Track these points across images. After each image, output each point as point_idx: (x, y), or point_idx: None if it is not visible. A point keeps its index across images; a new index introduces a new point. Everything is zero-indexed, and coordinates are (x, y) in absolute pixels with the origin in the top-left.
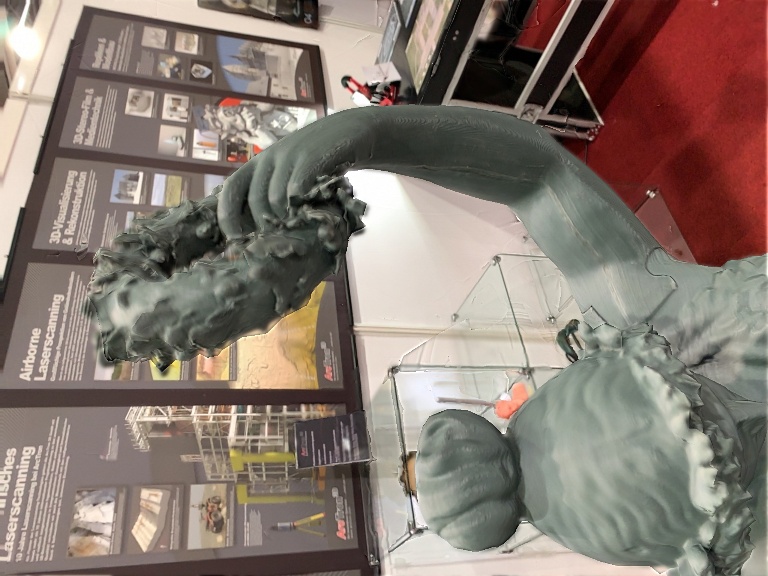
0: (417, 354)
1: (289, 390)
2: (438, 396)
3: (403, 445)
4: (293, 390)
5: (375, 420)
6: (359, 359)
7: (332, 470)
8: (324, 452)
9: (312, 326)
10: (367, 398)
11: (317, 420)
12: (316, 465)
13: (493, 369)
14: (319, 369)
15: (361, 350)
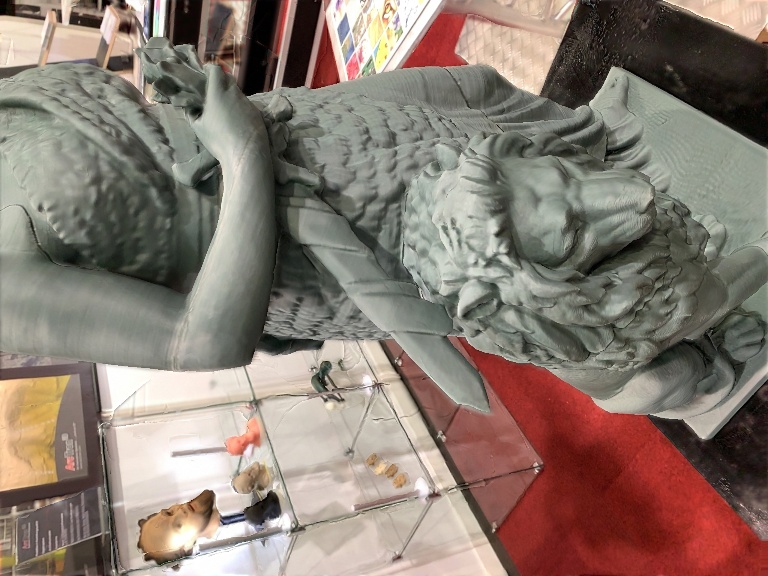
0: (129, 405)
1: (20, 489)
2: (173, 451)
3: (108, 494)
4: (25, 488)
5: (127, 501)
6: (109, 444)
7: (72, 563)
8: (49, 539)
9: (52, 420)
10: (117, 481)
11: (43, 508)
12: (39, 555)
13: (217, 408)
14: (59, 461)
15: (112, 435)
